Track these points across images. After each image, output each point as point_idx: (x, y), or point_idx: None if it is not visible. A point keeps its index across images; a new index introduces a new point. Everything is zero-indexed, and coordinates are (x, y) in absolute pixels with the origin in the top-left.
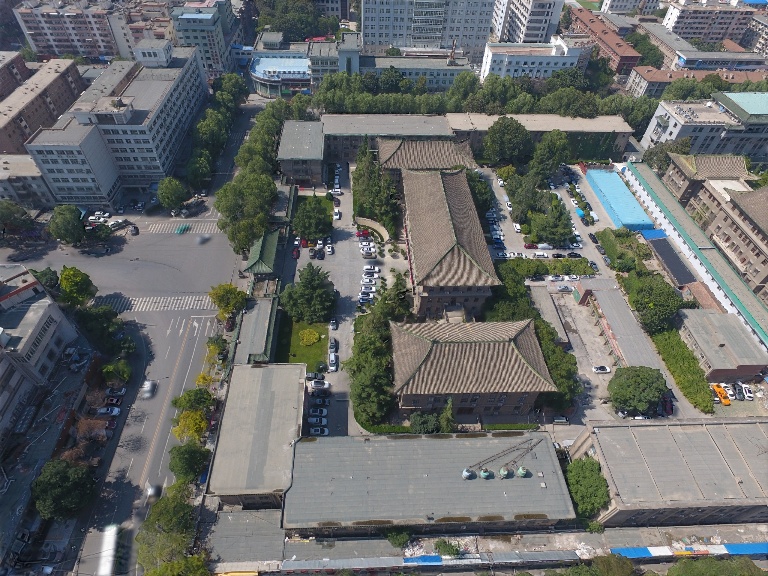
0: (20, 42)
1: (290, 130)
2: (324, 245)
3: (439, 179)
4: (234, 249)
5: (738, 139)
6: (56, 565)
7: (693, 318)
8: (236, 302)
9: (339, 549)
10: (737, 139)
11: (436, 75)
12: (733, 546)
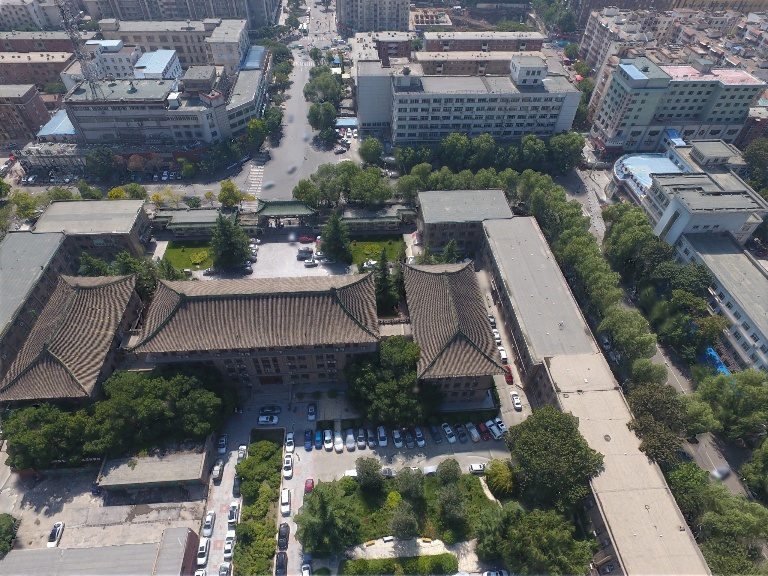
0: (580, 38)
1: (482, 194)
2: (319, 259)
3: None
4: None
5: None
6: (79, 180)
7: None
8: None
9: None
10: None
11: (760, 346)
12: None
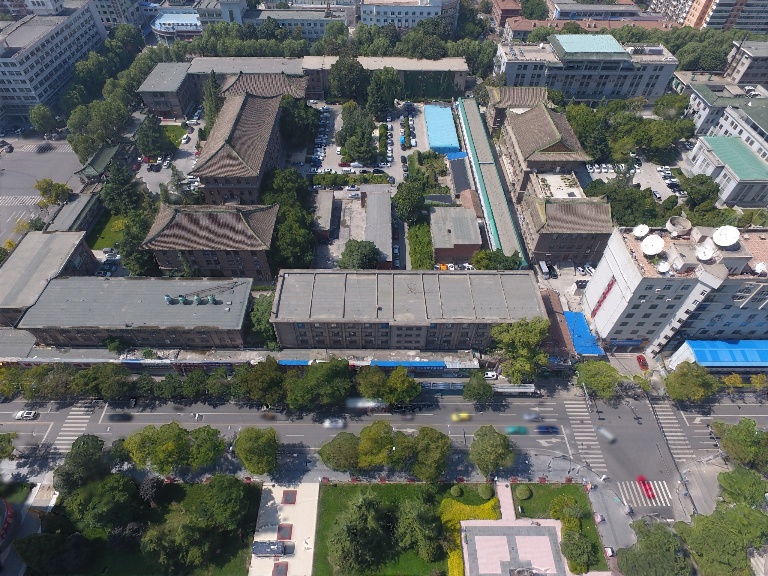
0: None
1: (159, 70)
2: (164, 161)
3: (244, 99)
4: (80, 161)
5: (563, 77)
6: None
7: (439, 213)
8: (56, 193)
9: (71, 354)
10: (561, 76)
11: (313, 26)
12: (378, 362)
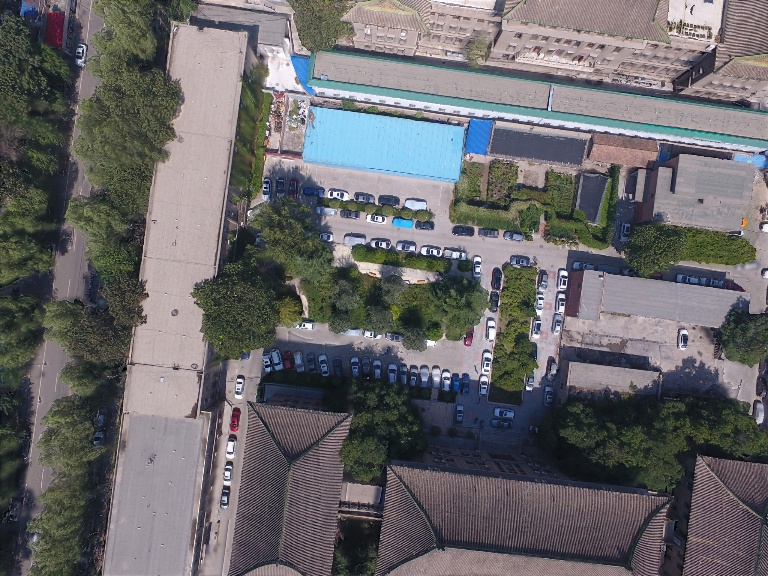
0: None
1: None
2: None
3: (459, 550)
4: None
5: None
6: None
7: (669, 208)
8: None
9: None
10: None
11: None
12: None
